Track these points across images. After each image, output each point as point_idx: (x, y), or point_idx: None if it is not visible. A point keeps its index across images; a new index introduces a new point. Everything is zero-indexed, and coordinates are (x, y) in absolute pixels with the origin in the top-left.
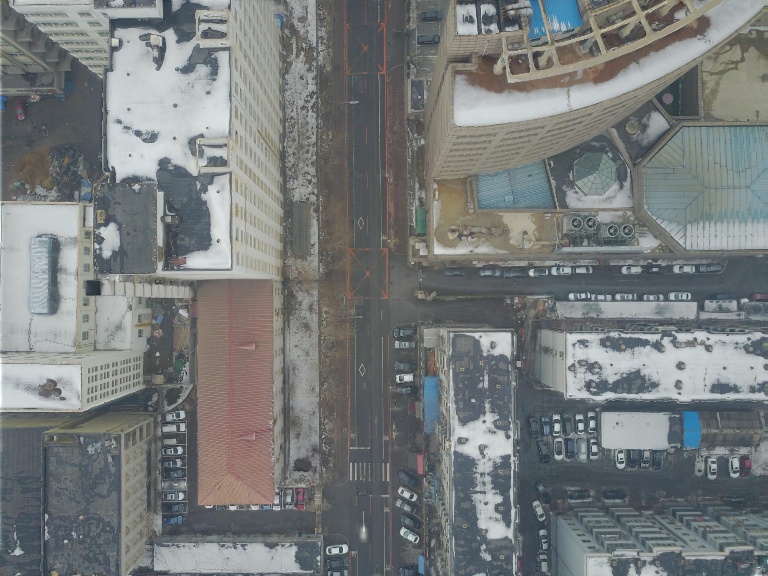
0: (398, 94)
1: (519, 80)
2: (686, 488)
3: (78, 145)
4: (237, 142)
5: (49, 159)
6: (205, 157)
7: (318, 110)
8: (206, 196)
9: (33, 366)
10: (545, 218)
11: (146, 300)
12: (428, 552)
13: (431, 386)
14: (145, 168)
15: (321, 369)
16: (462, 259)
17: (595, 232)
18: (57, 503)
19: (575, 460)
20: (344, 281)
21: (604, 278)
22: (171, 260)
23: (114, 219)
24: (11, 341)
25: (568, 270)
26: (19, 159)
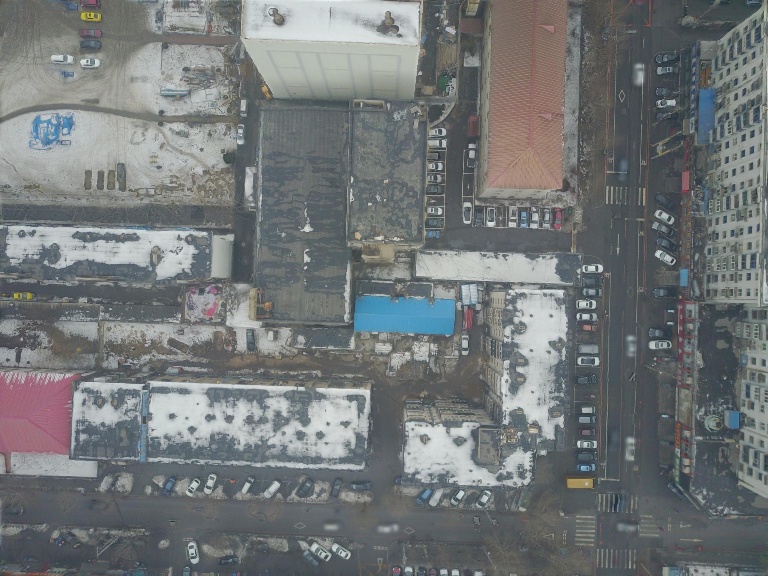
0: None
1: None
2: None
3: None
4: None
5: None
6: None
7: None
8: None
9: (372, 3)
10: None
11: None
12: (693, 264)
13: (706, 97)
14: None
15: (581, 93)
16: None
17: None
18: (362, 167)
19: None
20: None
21: None
22: None
23: None
24: None
25: None
26: None
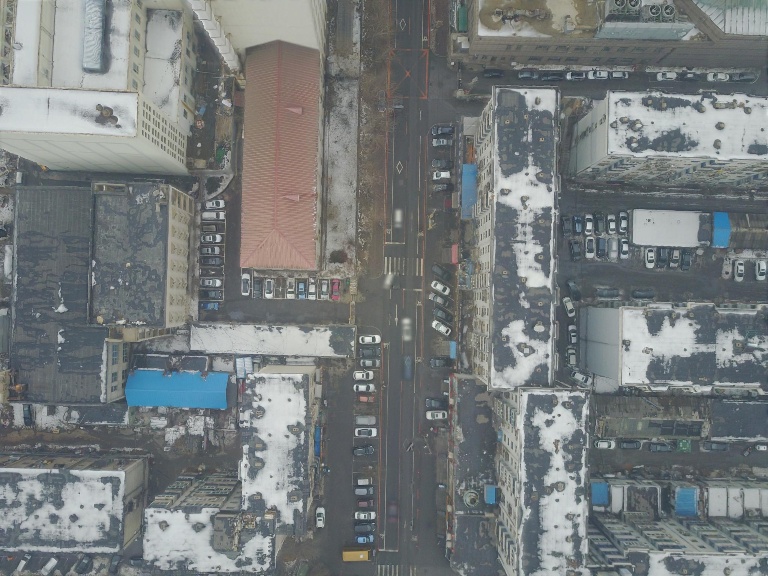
0: None
1: None
2: (713, 290)
3: None
4: None
5: None
6: None
7: None
8: None
9: (91, 93)
10: (587, 4)
11: (191, 86)
12: (460, 336)
13: (469, 173)
14: None
15: (359, 165)
16: (503, 51)
17: (637, 13)
18: (105, 250)
19: (605, 260)
20: (385, 80)
21: (639, 85)
22: None
23: None
24: None
25: (605, 73)
26: None
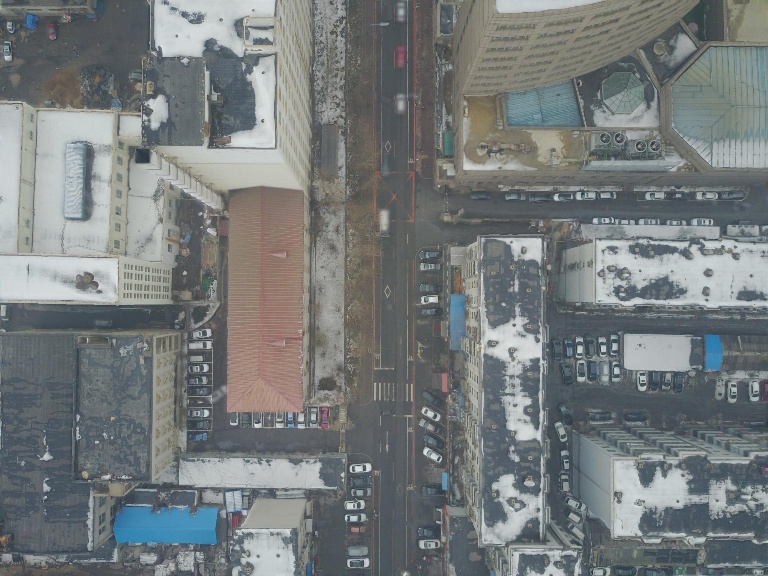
0: (426, 20)
1: None
2: (706, 411)
3: (109, 66)
4: (281, 28)
5: (80, 79)
6: (251, 39)
7: (347, 35)
8: (251, 77)
9: (71, 259)
10: (573, 136)
11: (175, 217)
12: (452, 468)
13: (457, 303)
14: (191, 49)
15: (347, 290)
16: (489, 179)
17: (623, 148)
18: (89, 404)
19: (597, 383)
20: (371, 203)
21: (628, 204)
22: (216, 139)
23: (163, 91)
24: (44, 246)
25: (593, 195)
26: (50, 79)
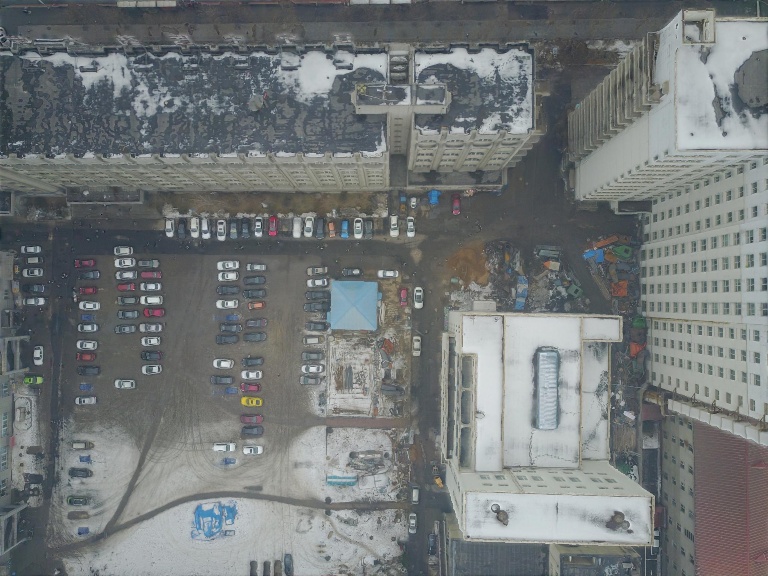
0: None
1: None
2: None
3: (513, 241)
4: None
5: (483, 255)
6: None
7: None
8: None
9: (601, 498)
10: None
11: None
12: None
13: None
14: None
15: None
16: None
17: None
18: None
19: None
20: None
21: None
22: None
23: None
24: (512, 456)
25: None
26: (452, 254)
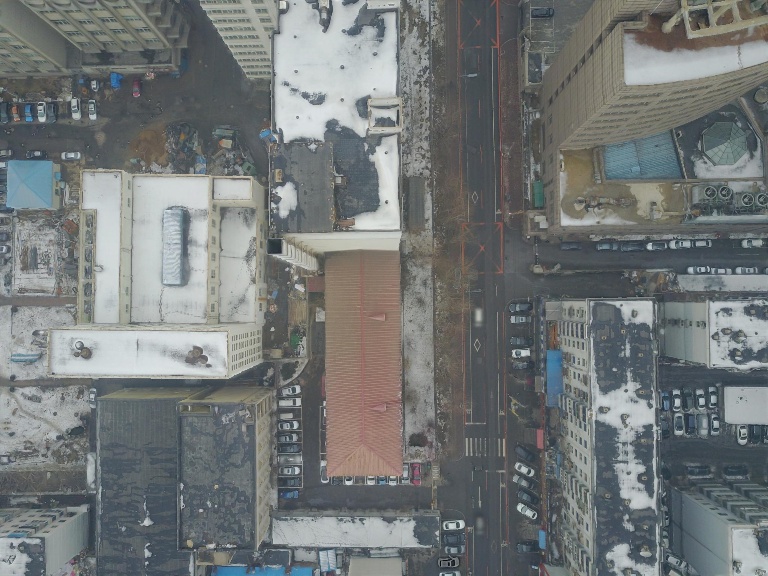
0: (512, 68)
1: (699, 35)
2: None
3: (192, 122)
4: None
5: (164, 136)
6: (373, 118)
7: (431, 85)
8: (374, 157)
9: (180, 333)
10: (673, 189)
11: (264, 275)
12: (550, 527)
13: (553, 359)
14: (313, 130)
15: (436, 344)
16: (584, 232)
17: (728, 202)
18: (192, 472)
19: (695, 436)
20: (459, 256)
21: (723, 252)
22: (340, 221)
23: (291, 178)
24: (143, 312)
25: (687, 243)
26: (134, 136)
